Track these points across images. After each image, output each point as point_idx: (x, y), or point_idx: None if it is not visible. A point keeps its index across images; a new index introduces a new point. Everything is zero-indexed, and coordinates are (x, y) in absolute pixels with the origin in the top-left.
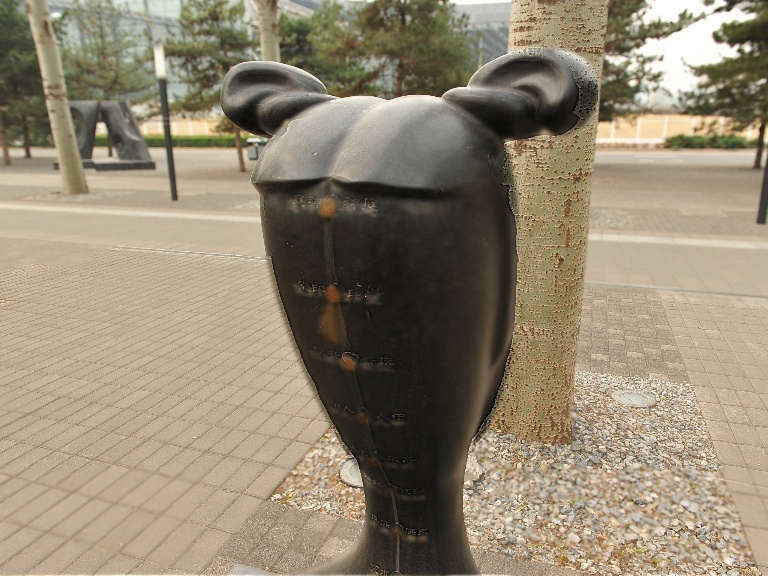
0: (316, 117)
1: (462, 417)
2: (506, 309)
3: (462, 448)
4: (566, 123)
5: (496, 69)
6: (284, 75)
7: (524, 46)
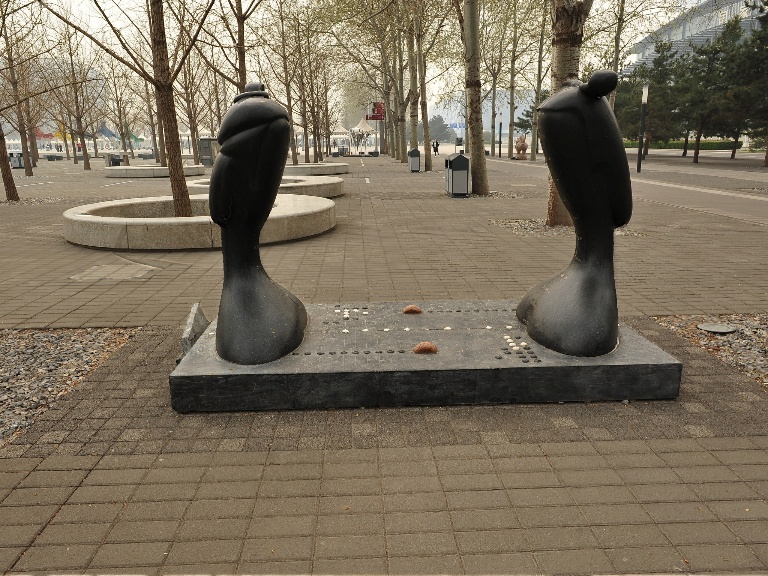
0: None
1: (579, 187)
2: (592, 150)
3: (589, 205)
4: (600, 90)
5: None
6: None
7: None
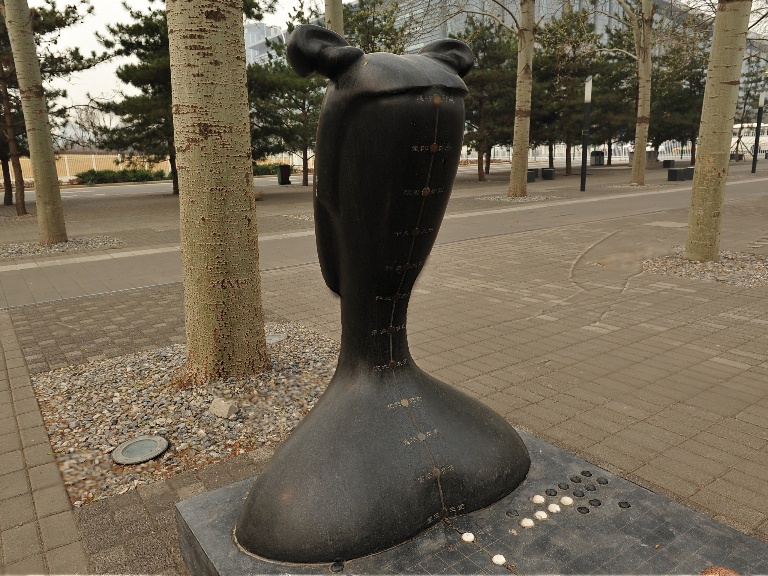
0: (380, 58)
1: None
2: None
3: None
4: None
5: (440, 44)
6: (329, 33)
7: (197, 50)
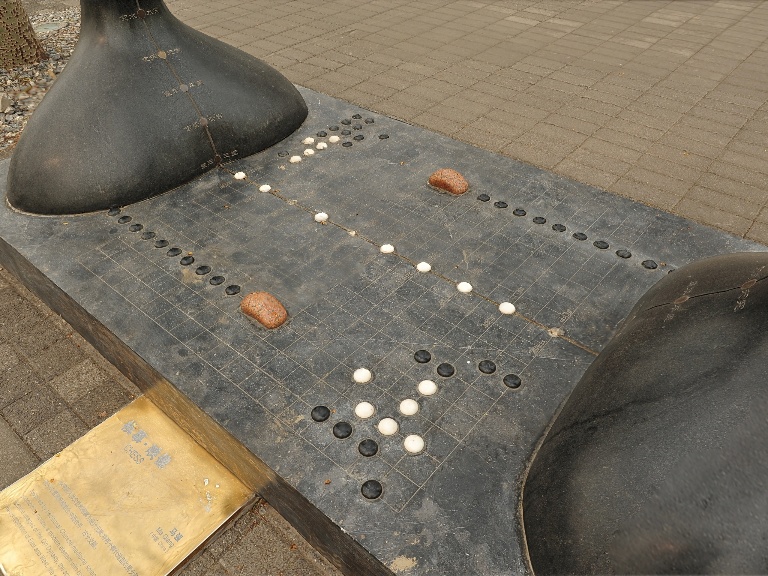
0: None
1: None
2: None
3: None
4: None
5: None
6: None
7: None
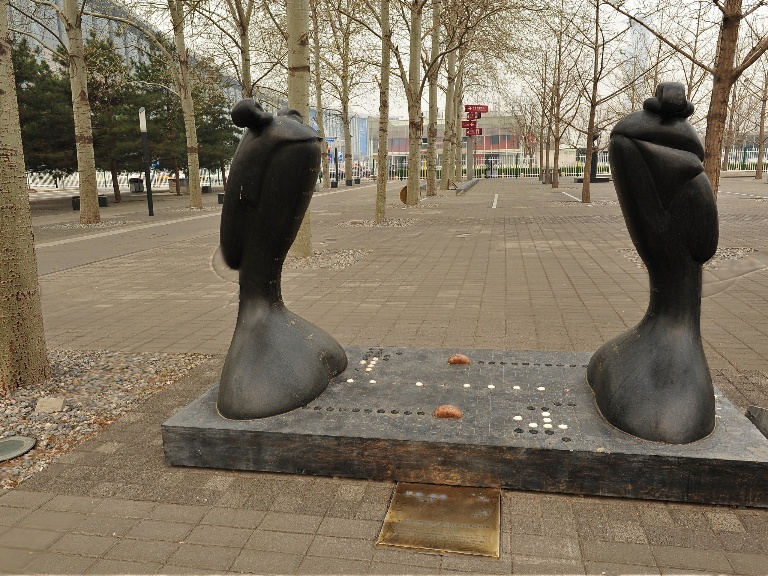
0: None
1: None
2: None
3: None
4: None
5: None
6: None
7: None
